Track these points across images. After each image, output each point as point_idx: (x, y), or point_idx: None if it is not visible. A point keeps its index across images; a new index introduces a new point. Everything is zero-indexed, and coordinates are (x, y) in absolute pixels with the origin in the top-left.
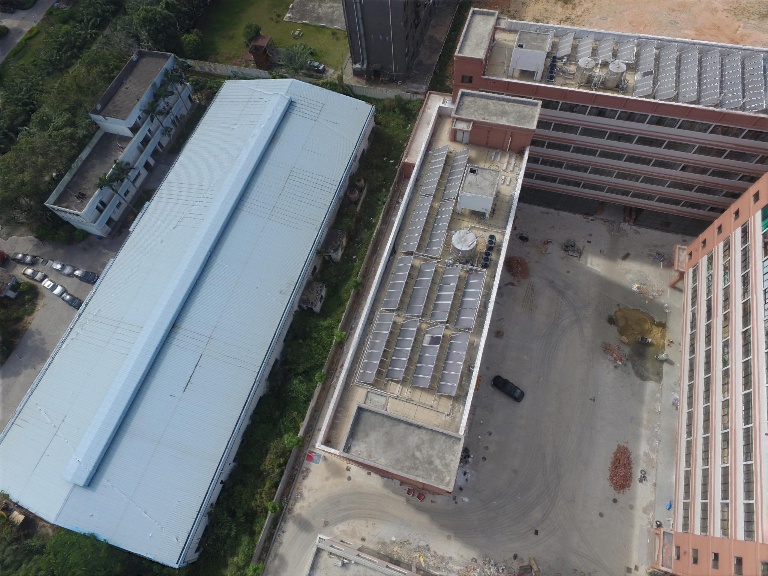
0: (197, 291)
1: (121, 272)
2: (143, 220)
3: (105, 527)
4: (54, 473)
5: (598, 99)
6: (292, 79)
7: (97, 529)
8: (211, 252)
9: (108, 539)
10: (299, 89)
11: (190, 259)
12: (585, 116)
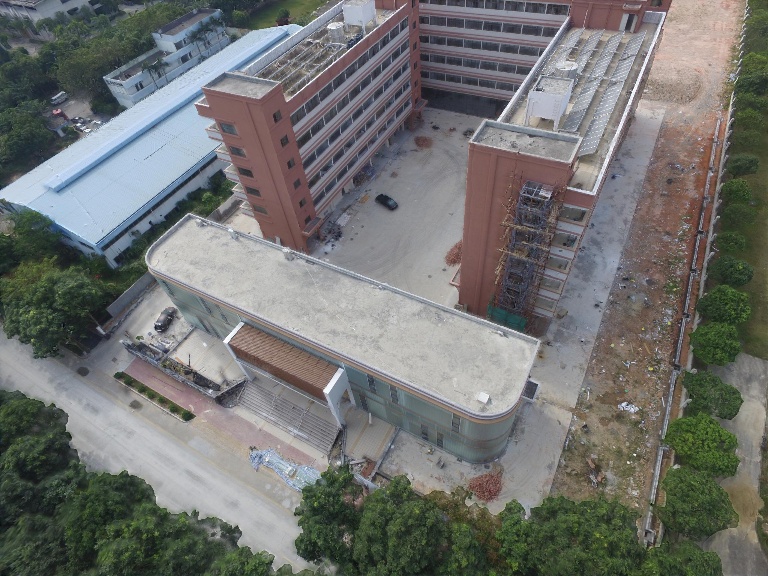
0: (178, 113)
1: (135, 109)
2: (163, 89)
3: (58, 214)
4: (39, 186)
5: None
6: (294, 24)
7: (52, 214)
8: (197, 96)
9: (56, 221)
10: (296, 29)
11: (180, 95)
12: (465, 8)
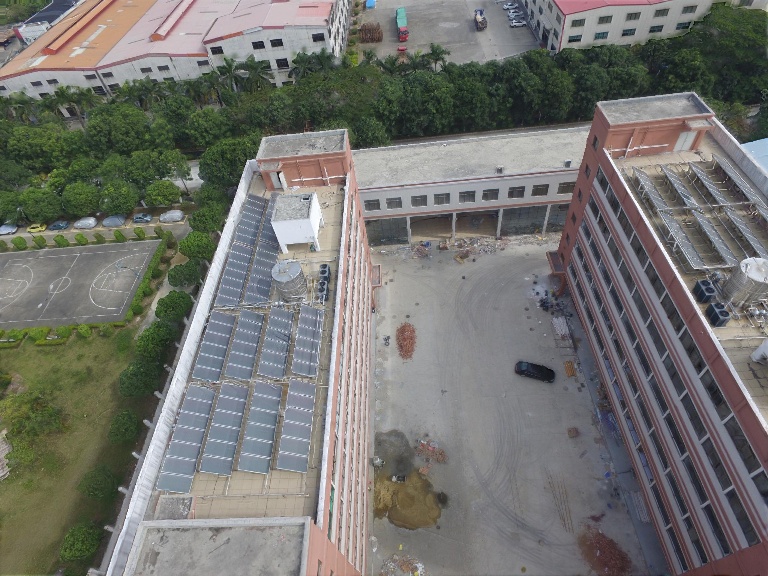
0: None
1: None
2: None
3: None
4: None
5: None
6: None
7: None
8: None
9: None
10: None
11: None
12: None
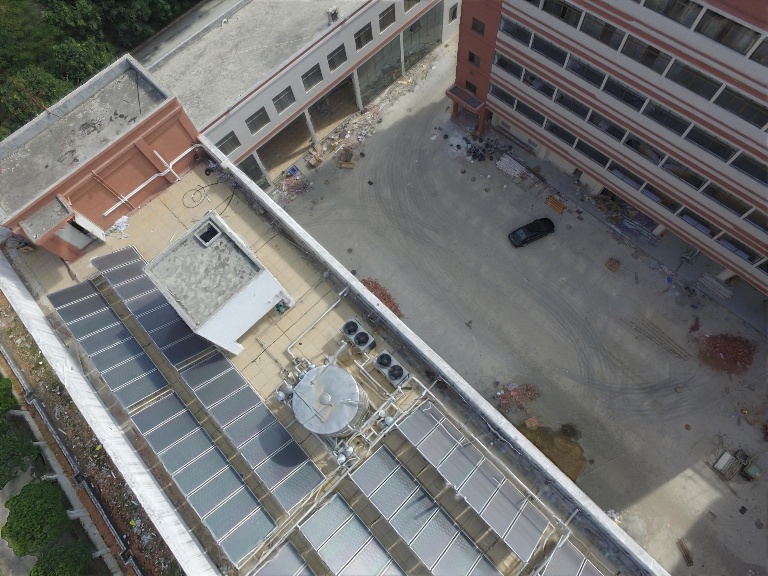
0: None
1: None
2: None
3: None
4: None
5: None
6: None
7: None
8: None
9: None
10: None
11: None
12: None
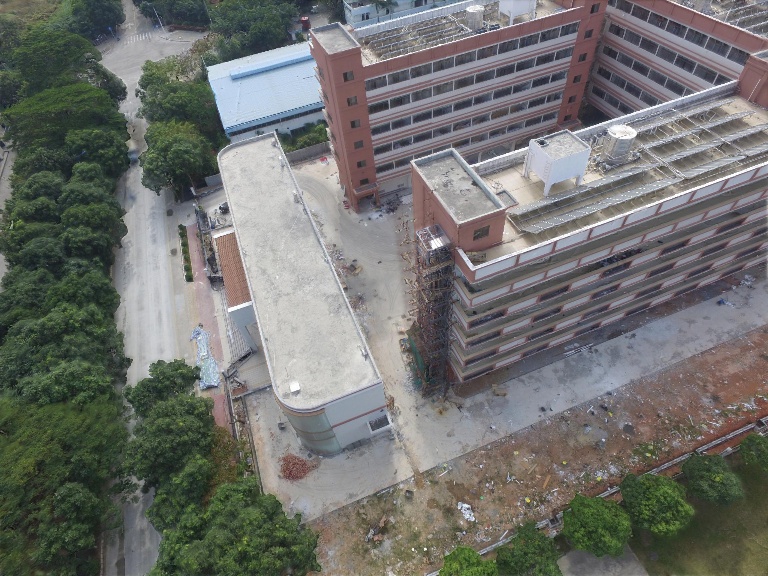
0: None
1: None
2: None
3: (221, 96)
4: None
5: (675, 11)
6: None
7: (218, 94)
8: None
9: (217, 100)
10: None
11: None
12: (664, 32)
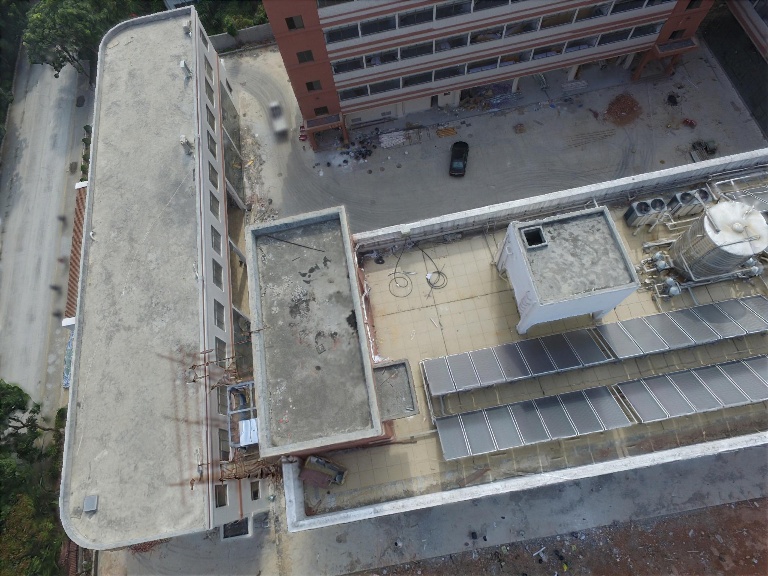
0: None
1: None
2: None
3: None
4: None
5: None
6: None
7: None
8: None
9: None
10: None
11: None
12: None
